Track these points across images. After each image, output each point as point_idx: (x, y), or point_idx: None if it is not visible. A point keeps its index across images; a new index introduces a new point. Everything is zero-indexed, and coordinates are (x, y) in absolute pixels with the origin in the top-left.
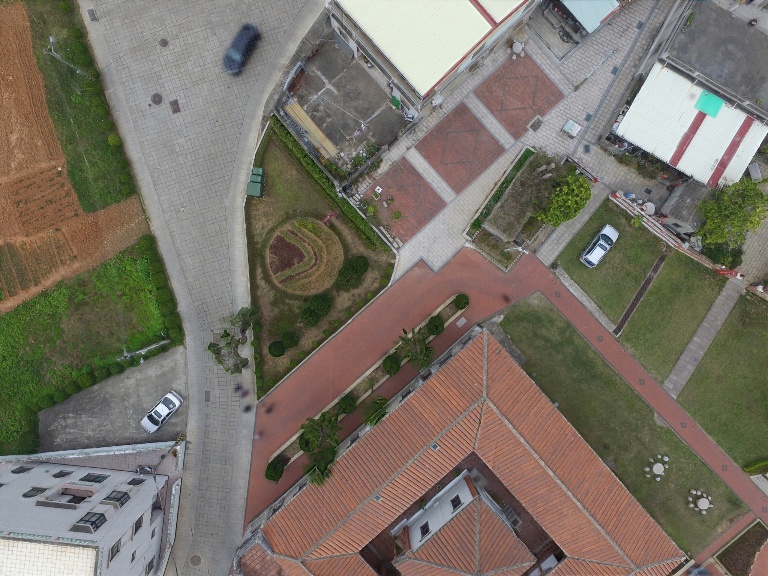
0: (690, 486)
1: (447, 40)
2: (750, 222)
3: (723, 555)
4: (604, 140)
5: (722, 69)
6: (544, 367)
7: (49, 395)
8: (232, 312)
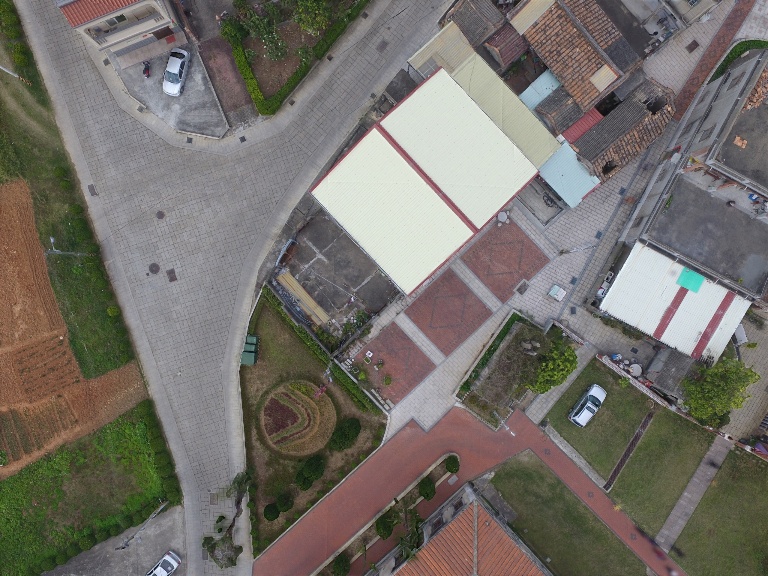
0: None
1: (430, 244)
2: (734, 402)
3: None
4: (589, 306)
5: (702, 247)
6: (536, 522)
7: (51, 557)
8: (228, 472)
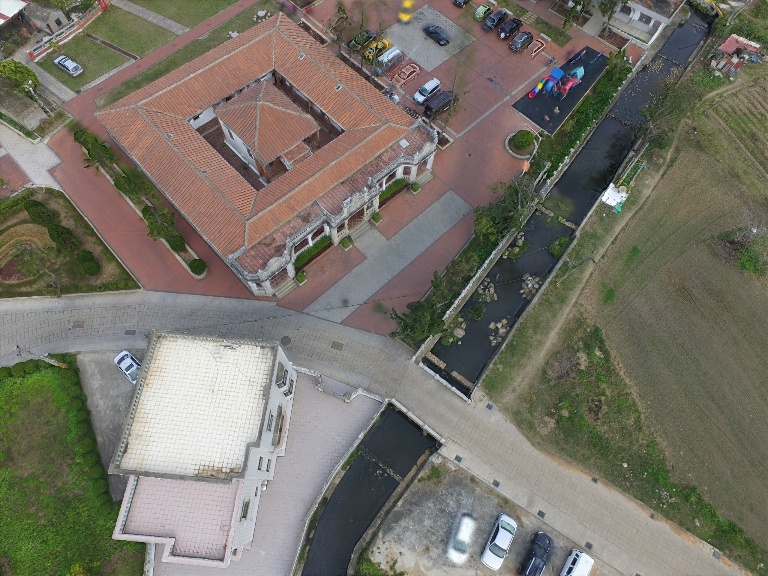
0: (252, 22)
1: None
2: None
3: (299, 5)
4: None
5: None
6: None
7: None
8: (56, 312)
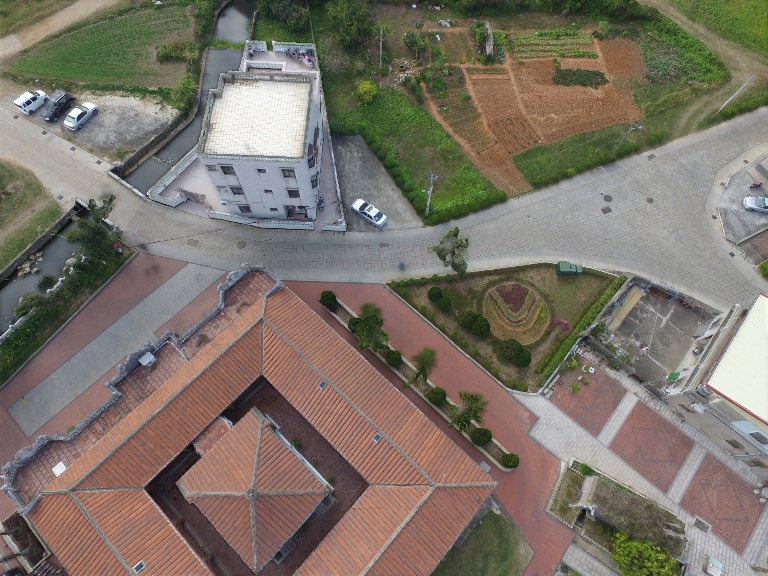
0: None
1: (765, 399)
2: None
3: None
4: None
5: None
6: (453, 571)
7: (375, 141)
8: None
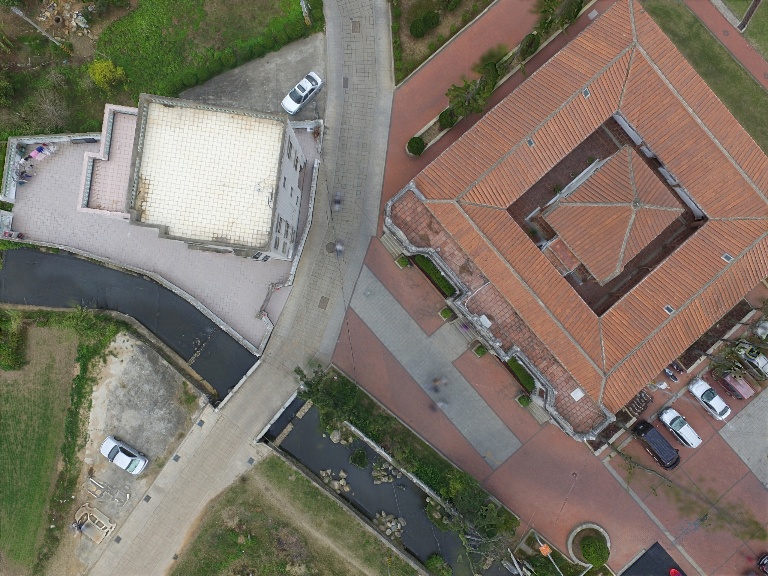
0: None
1: None
2: None
3: None
4: None
5: None
6: None
7: None
8: (371, 1)
